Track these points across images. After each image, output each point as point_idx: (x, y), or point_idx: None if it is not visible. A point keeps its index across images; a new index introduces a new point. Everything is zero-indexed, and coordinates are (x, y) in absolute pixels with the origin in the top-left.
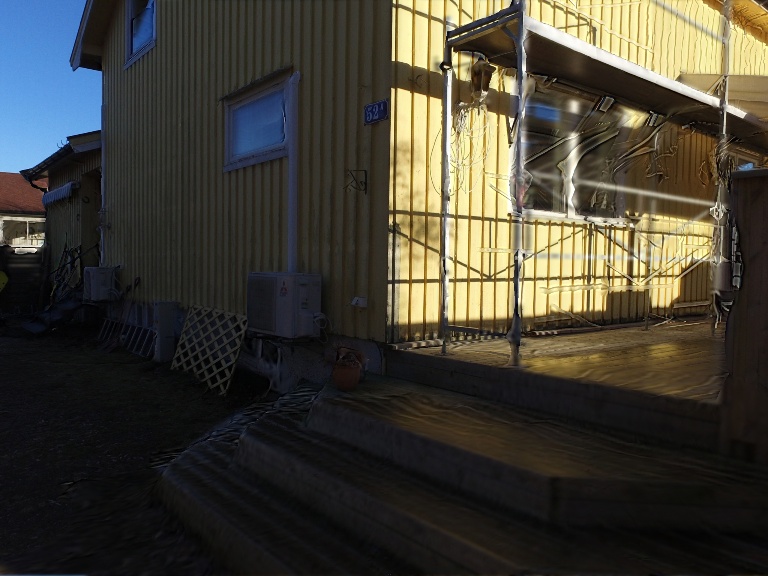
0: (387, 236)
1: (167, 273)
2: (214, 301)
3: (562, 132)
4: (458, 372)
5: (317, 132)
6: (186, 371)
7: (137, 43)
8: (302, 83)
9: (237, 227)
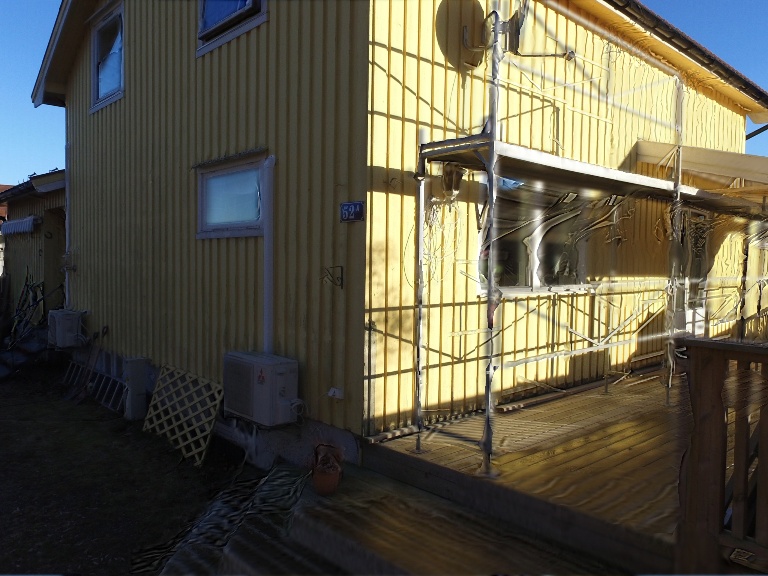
0: (363, 334)
1: (137, 327)
2: (187, 364)
3: (528, 217)
4: (433, 474)
5: (293, 219)
6: (159, 435)
7: (104, 88)
8: (277, 168)
9: (211, 296)
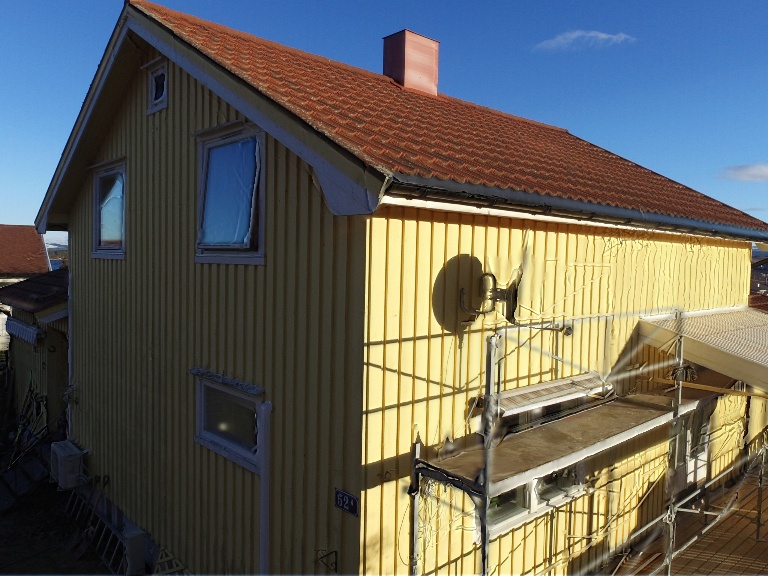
0: None
1: (137, 494)
2: (185, 558)
3: None
4: None
5: (289, 475)
6: None
7: (105, 235)
8: (274, 416)
9: (209, 504)
